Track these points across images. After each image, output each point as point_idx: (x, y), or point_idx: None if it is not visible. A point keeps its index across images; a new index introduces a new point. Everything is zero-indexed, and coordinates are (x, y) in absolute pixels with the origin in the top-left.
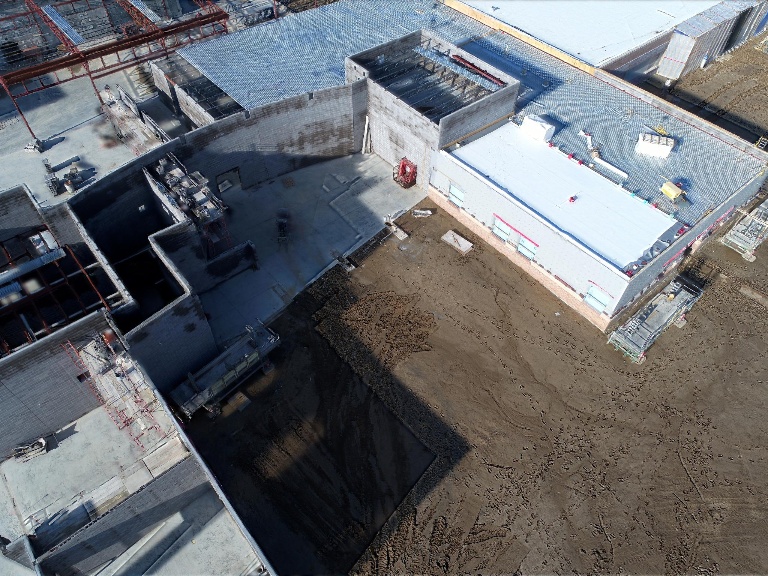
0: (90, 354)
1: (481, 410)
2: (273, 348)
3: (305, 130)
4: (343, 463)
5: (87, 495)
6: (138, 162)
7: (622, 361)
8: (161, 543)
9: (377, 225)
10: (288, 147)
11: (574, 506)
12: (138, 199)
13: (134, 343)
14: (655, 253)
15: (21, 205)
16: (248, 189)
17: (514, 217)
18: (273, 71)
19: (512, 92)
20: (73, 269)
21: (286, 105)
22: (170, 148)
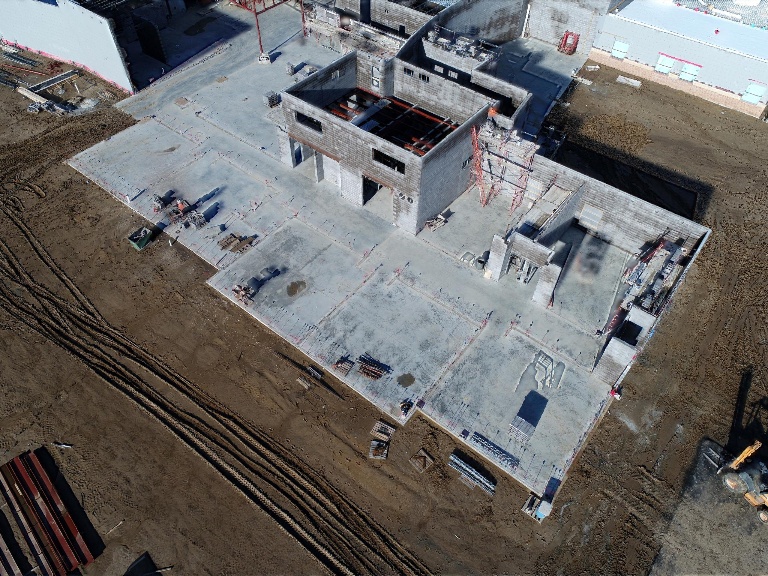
0: (486, 136)
1: (708, 168)
2: None
3: (494, 16)
4: None
5: (523, 219)
6: (419, 32)
7: None
8: (561, 256)
9: (566, 78)
10: (482, 31)
11: None
12: None
13: (513, 125)
14: None
15: (351, 68)
16: None
17: (680, 49)
18: None
19: None
20: (403, 109)
21: None
22: (432, 23)
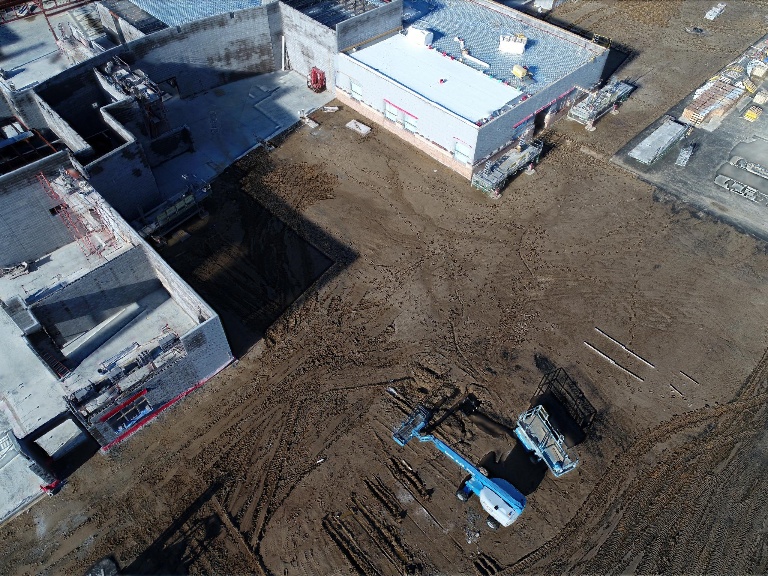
0: (59, 184)
1: (371, 233)
2: (206, 196)
3: (230, 47)
4: (263, 269)
5: (63, 279)
6: (89, 63)
7: (483, 198)
8: (123, 320)
9: (293, 119)
10: (217, 62)
11: (437, 285)
12: (91, 96)
13: (93, 174)
14: (502, 112)
15: None
16: (186, 99)
17: (398, 98)
18: (203, 5)
19: (397, 7)
20: (41, 144)
21: (211, 22)
22: (115, 53)
